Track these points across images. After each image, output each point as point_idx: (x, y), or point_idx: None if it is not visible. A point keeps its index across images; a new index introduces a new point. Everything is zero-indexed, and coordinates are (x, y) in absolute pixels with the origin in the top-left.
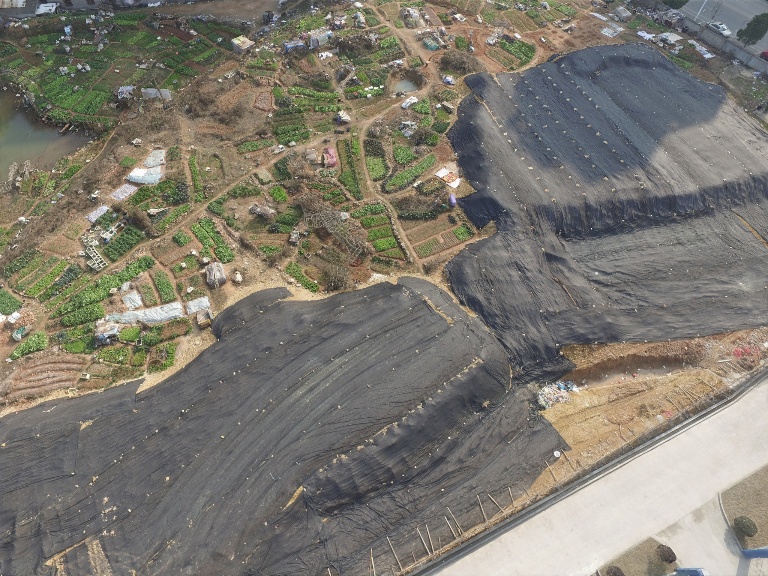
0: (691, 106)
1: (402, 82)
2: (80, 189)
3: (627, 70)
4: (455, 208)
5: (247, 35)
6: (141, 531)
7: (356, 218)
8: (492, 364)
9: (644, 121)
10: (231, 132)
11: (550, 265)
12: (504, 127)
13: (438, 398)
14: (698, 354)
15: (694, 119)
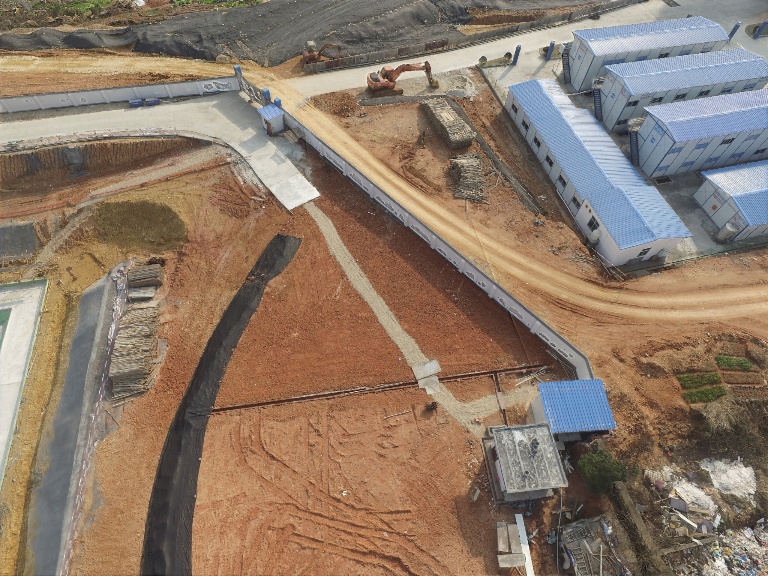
0: None
1: None
2: None
3: None
4: None
5: None
6: (260, 40)
7: None
8: (429, 5)
9: None
10: None
11: None
12: None
13: (400, 9)
14: (542, 15)
15: None
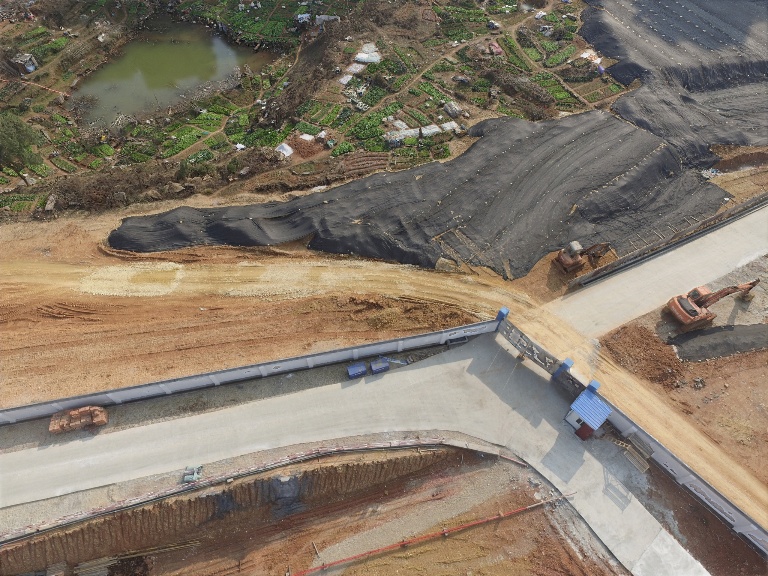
0: (759, 10)
1: (525, 5)
2: (320, 68)
3: None
4: (604, 75)
5: None
6: (483, 226)
7: (533, 82)
8: (671, 149)
9: (727, 19)
10: (414, 34)
11: (685, 104)
12: (626, 23)
13: (645, 162)
14: None
15: (764, 17)
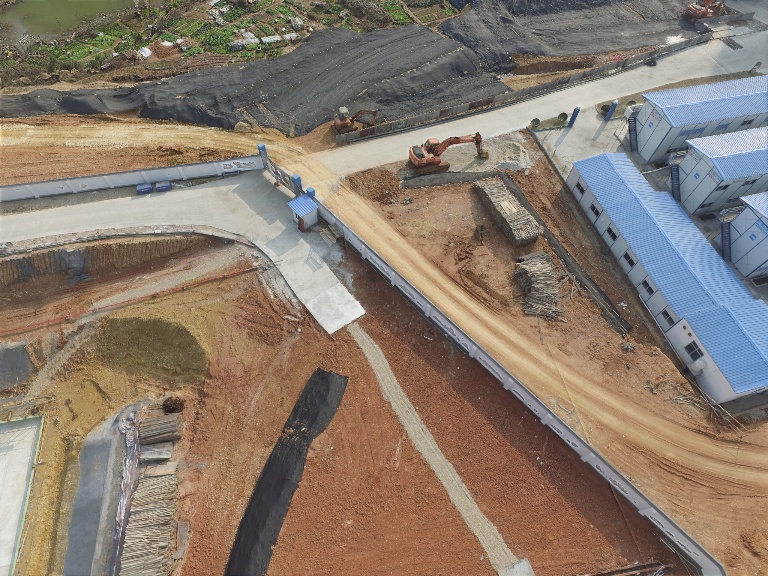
0: None
1: None
2: None
3: None
4: (444, 2)
5: None
6: (283, 102)
7: (380, 7)
8: (469, 54)
9: None
10: None
11: (504, 24)
12: None
13: (438, 61)
14: (593, 61)
15: None
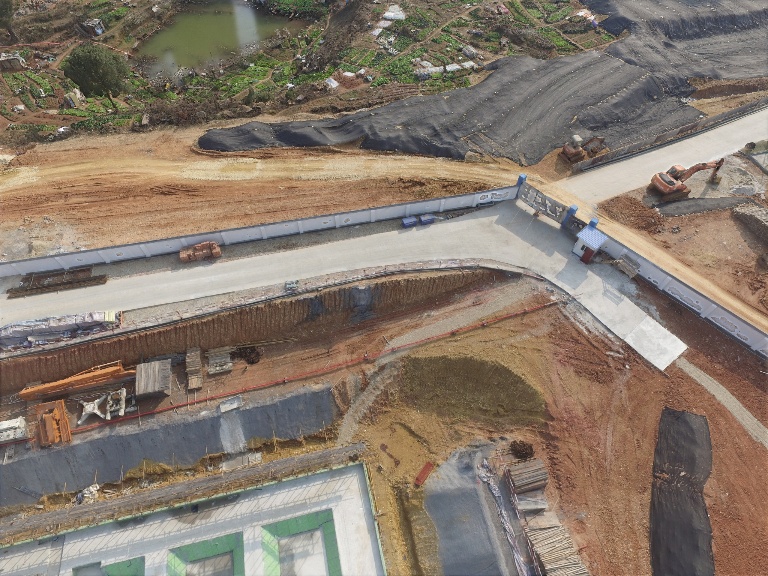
0: None
1: None
2: None
3: None
4: (597, 28)
5: None
6: (501, 131)
7: None
8: (655, 79)
9: None
10: None
11: None
12: None
13: (633, 86)
14: (767, 84)
15: None
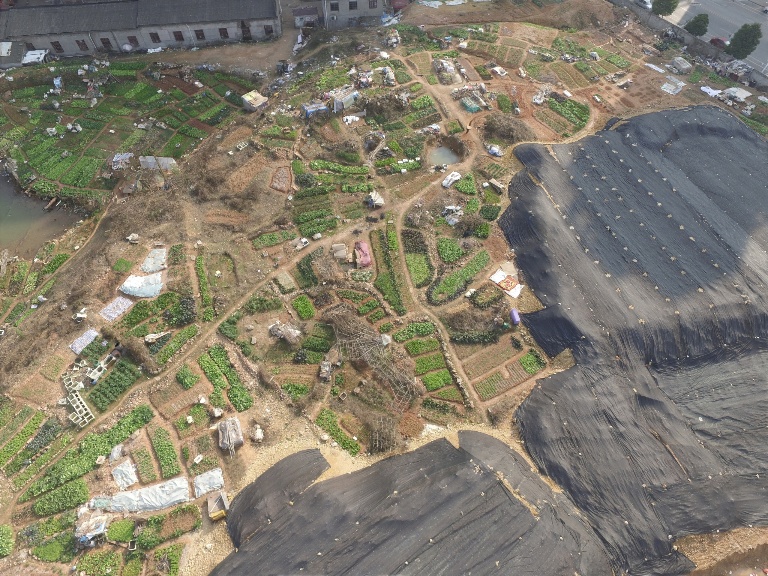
0: None
1: (439, 150)
2: (63, 303)
3: (702, 140)
4: (519, 327)
5: (259, 88)
6: None
7: (400, 342)
8: None
9: (732, 208)
10: (245, 221)
11: (644, 411)
12: (569, 218)
13: None
14: None
15: None
